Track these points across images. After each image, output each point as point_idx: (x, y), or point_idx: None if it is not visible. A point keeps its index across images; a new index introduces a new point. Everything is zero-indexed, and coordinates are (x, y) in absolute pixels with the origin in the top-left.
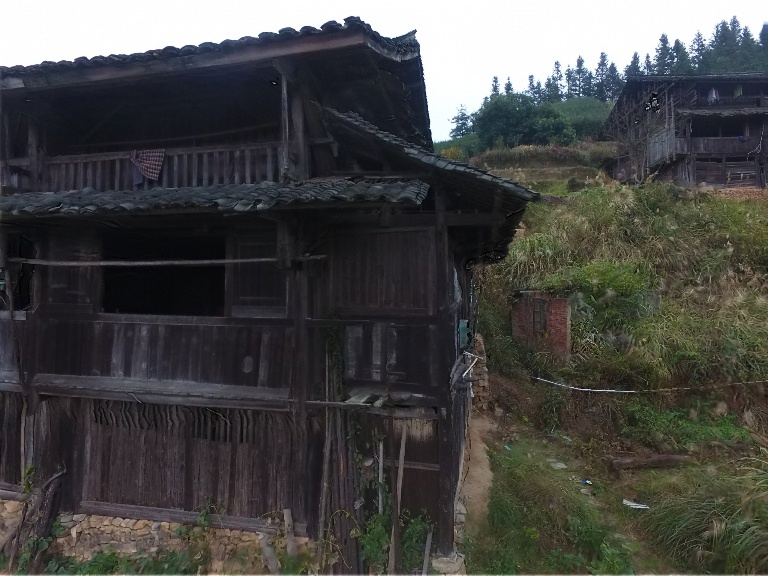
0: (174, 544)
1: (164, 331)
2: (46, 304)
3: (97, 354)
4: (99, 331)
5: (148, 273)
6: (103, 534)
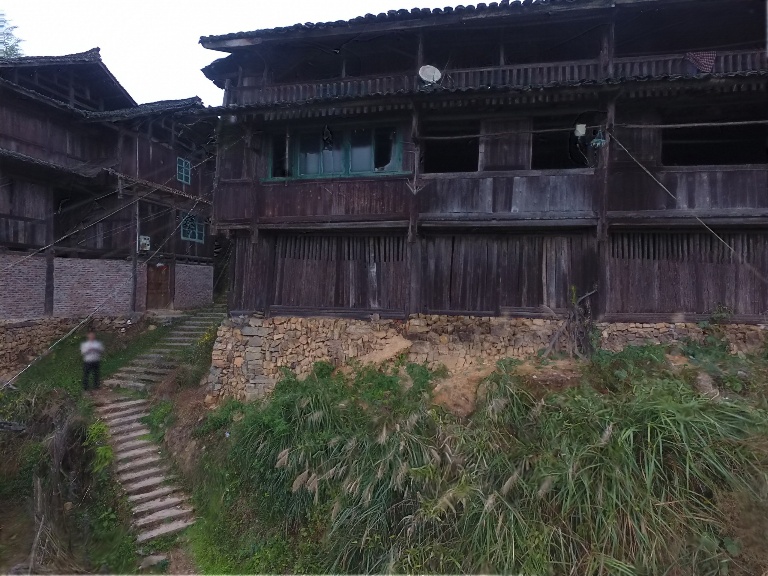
0: (693, 336)
1: (721, 176)
2: (613, 162)
3: (663, 194)
4: (663, 178)
5: (728, 131)
6: (628, 334)
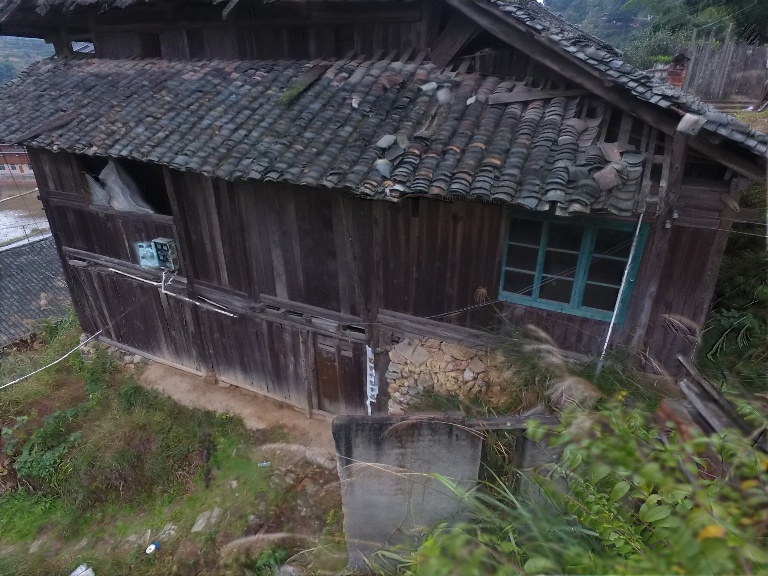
0: None
1: None
2: None
3: None
4: None
5: None
6: None
